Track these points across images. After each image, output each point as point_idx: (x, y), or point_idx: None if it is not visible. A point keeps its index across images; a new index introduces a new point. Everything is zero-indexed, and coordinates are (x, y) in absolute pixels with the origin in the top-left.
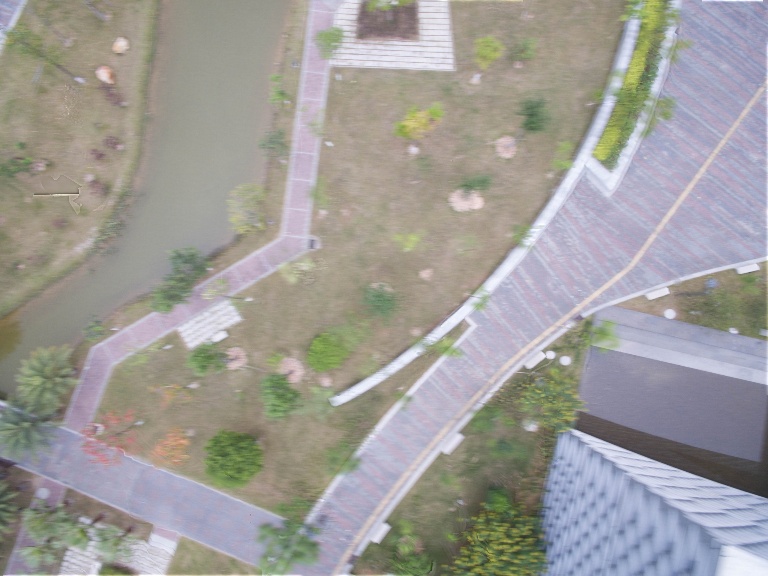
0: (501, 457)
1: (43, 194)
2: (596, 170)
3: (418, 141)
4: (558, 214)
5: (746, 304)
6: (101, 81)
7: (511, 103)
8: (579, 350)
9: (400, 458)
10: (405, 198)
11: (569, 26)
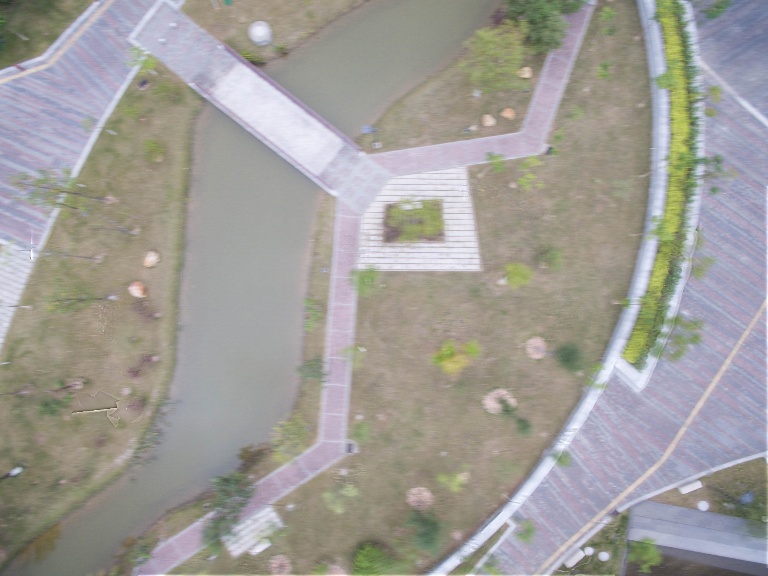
0: None
1: (81, 411)
2: (625, 370)
3: (449, 344)
4: (590, 411)
5: None
6: (134, 297)
7: (539, 304)
8: (617, 545)
9: None
10: (439, 402)
11: (592, 225)
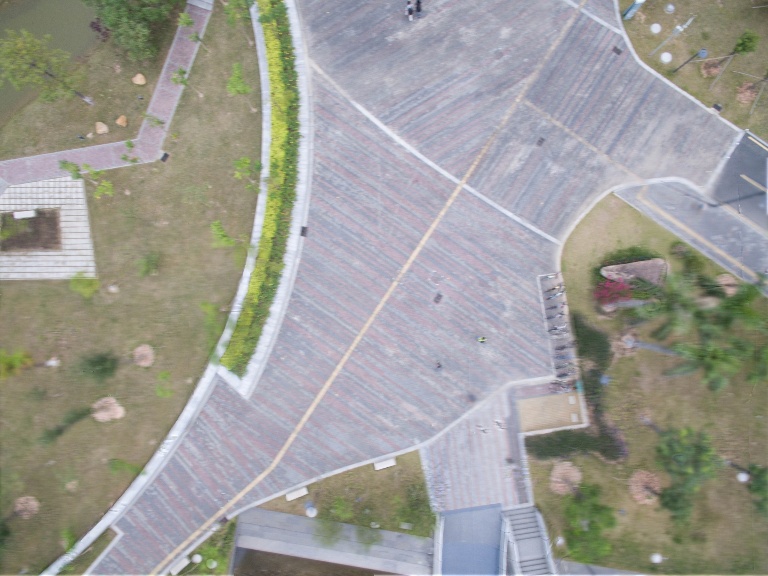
0: None
1: None
2: (227, 378)
3: (60, 353)
4: (199, 419)
5: (386, 498)
6: None
7: (148, 311)
8: (224, 553)
9: None
10: (49, 411)
11: (203, 231)
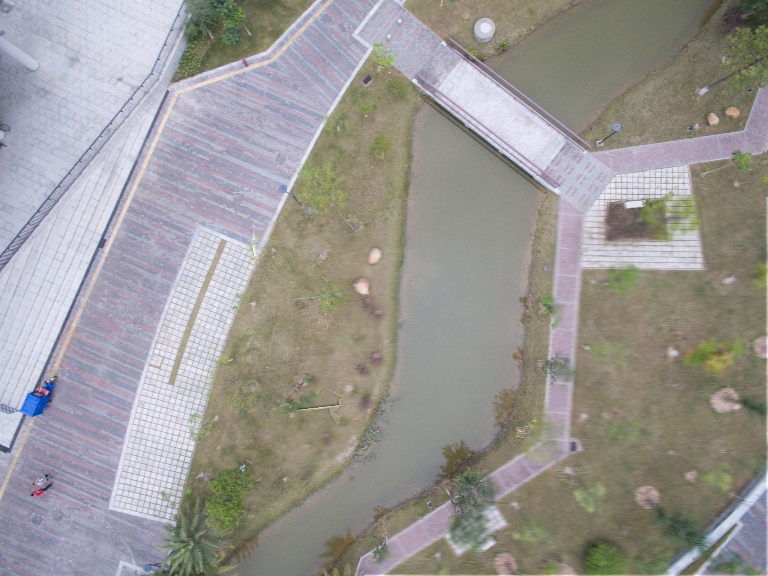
0: None
1: (305, 408)
2: None
3: (675, 343)
4: None
5: None
6: (359, 294)
7: (766, 303)
8: None
9: None
10: (666, 401)
11: None
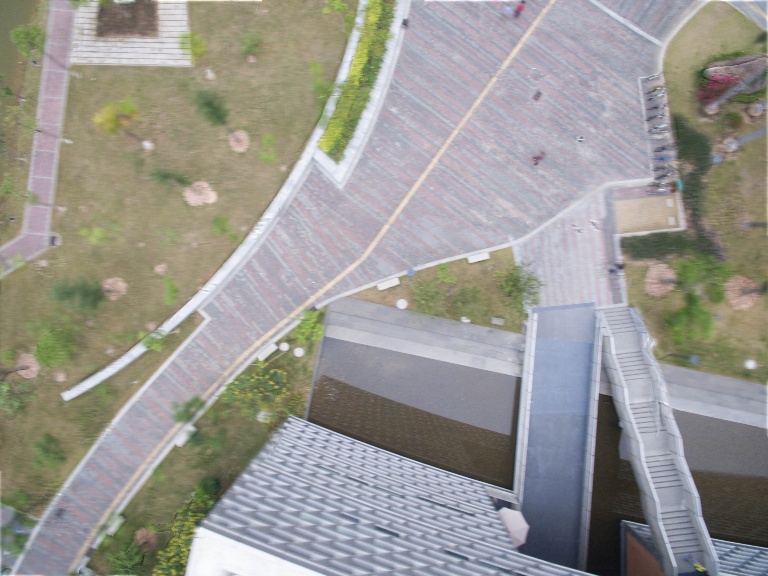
0: (236, 449)
1: None
2: (323, 162)
3: (154, 137)
4: (291, 207)
5: (478, 293)
6: None
7: (244, 97)
8: (312, 341)
9: (136, 451)
10: (140, 194)
11: (302, 20)
